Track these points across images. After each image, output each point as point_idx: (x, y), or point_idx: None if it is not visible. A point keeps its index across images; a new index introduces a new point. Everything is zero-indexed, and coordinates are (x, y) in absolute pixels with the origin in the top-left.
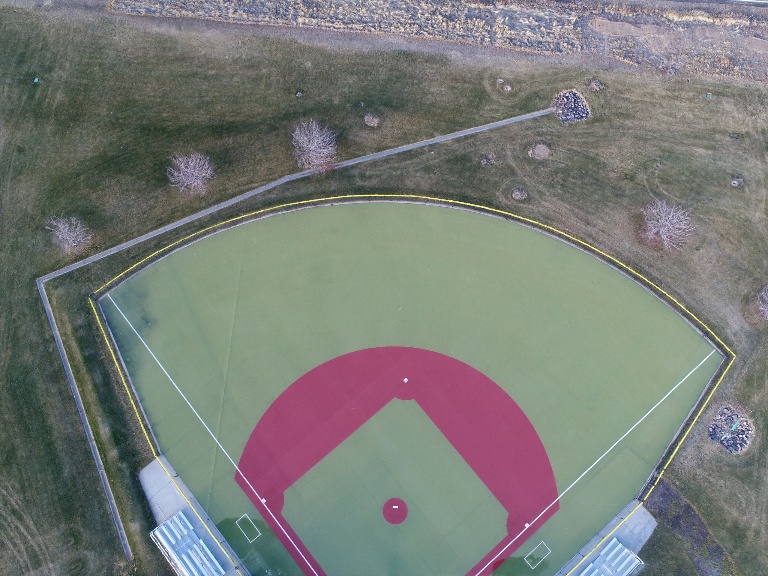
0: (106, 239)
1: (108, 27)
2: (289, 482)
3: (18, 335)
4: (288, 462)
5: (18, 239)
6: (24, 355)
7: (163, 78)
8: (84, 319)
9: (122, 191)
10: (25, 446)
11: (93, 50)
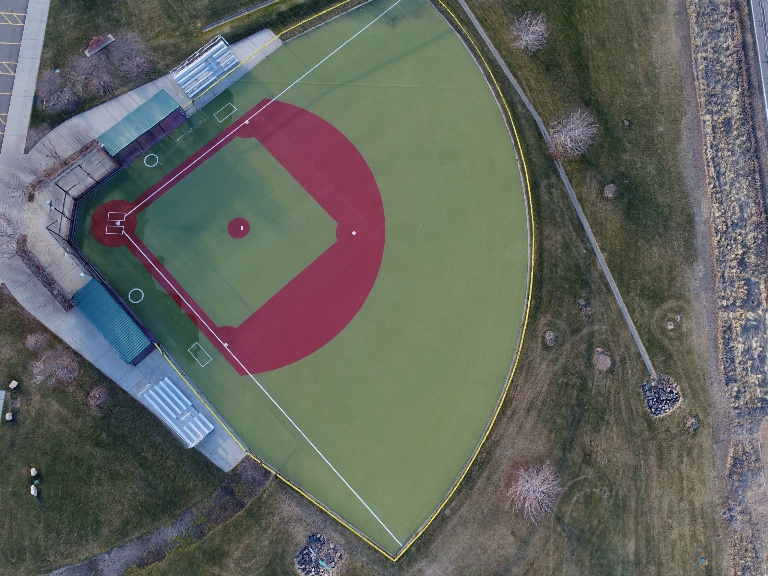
0: None
1: None
2: (262, 141)
3: None
4: (279, 139)
5: None
6: None
7: (622, 6)
8: None
9: None
10: None
11: None
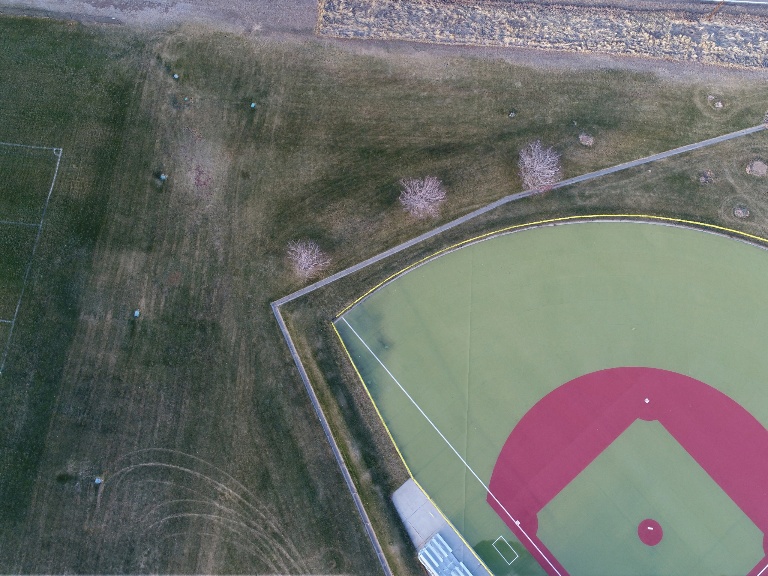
0: (335, 262)
1: (318, 51)
2: (541, 504)
3: (259, 359)
4: (538, 484)
5: (250, 263)
6: (267, 379)
7: (377, 101)
8: (322, 342)
9: (347, 214)
10: (278, 470)
11: (306, 74)
